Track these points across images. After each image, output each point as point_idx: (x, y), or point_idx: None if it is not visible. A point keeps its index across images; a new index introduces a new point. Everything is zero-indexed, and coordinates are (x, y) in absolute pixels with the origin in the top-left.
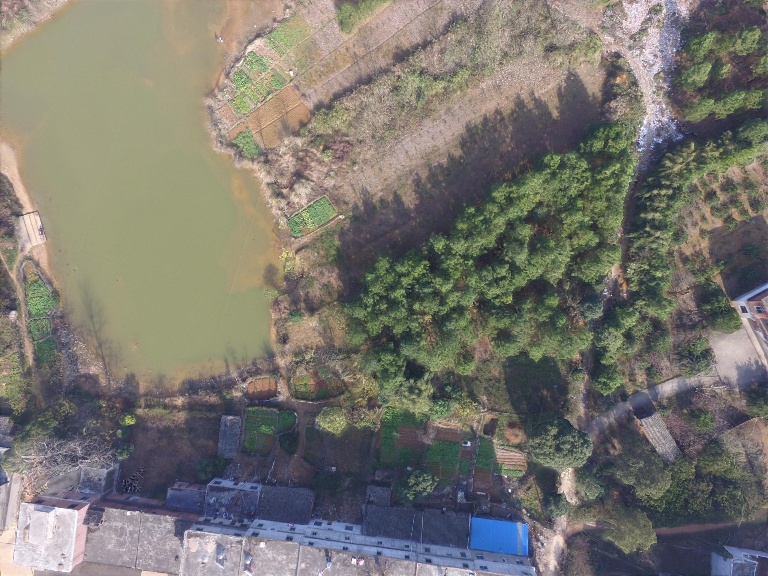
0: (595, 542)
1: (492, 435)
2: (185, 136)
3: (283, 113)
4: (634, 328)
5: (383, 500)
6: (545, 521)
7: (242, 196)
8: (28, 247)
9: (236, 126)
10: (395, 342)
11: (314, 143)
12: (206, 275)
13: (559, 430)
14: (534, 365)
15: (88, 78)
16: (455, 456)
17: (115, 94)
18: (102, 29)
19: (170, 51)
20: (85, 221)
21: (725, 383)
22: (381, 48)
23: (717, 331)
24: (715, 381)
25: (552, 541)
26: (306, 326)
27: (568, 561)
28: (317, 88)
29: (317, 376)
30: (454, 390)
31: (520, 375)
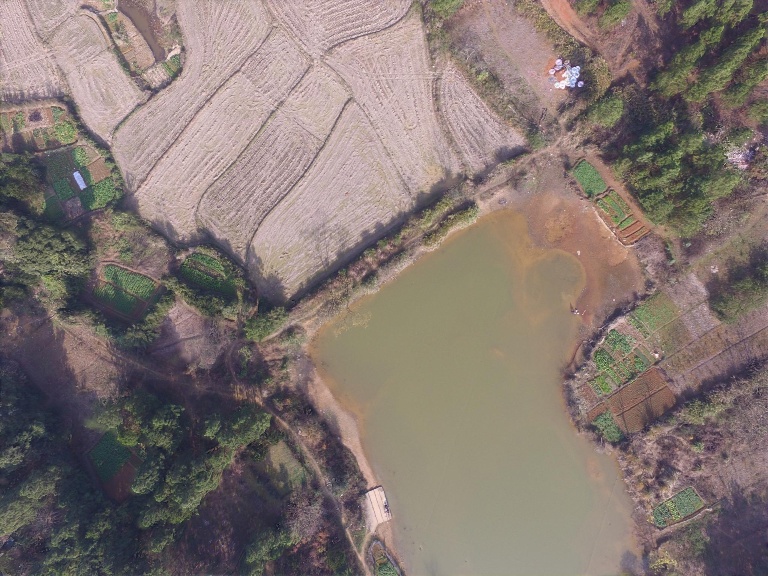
0: None
1: None
2: (538, 412)
3: (646, 396)
4: None
5: None
6: None
7: (599, 479)
8: (374, 526)
9: (596, 407)
10: None
11: (682, 432)
12: (559, 559)
13: None
14: None
15: (434, 345)
16: None
17: (463, 364)
18: (447, 293)
19: (522, 321)
20: (431, 497)
21: None
22: (756, 337)
23: None
24: None
25: None
26: None
27: None
28: (685, 374)
29: None
30: None
31: None
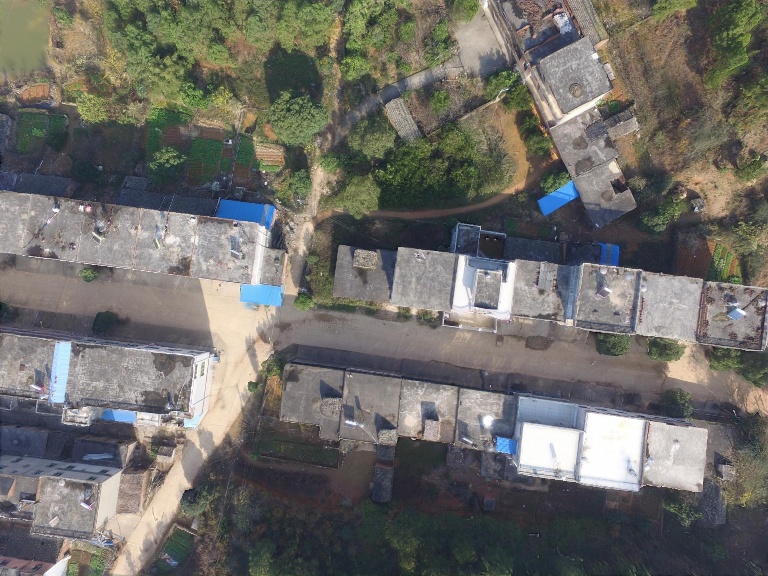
0: None
1: (252, 132)
2: None
3: None
4: (380, 17)
5: (138, 186)
6: (295, 208)
7: None
8: None
9: None
10: (144, 22)
11: None
12: None
13: (292, 96)
14: (293, 65)
15: None
16: (216, 152)
17: None
18: None
19: None
20: None
21: (468, 73)
22: None
23: (459, 20)
24: (459, 72)
25: (302, 227)
26: (80, 35)
27: (315, 244)
28: None
29: (89, 83)
30: (216, 89)
31: (280, 74)
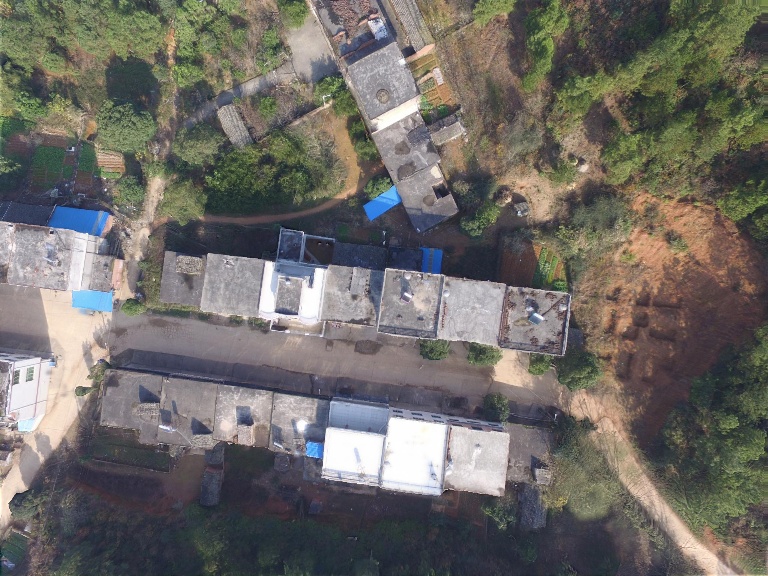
0: (174, 230)
1: (93, 140)
2: None
3: None
4: (212, 24)
5: None
6: (132, 214)
7: None
8: None
9: None
10: None
11: None
12: None
13: (115, 104)
14: (134, 72)
15: None
16: (58, 160)
17: None
18: None
19: None
20: None
21: (300, 79)
22: None
23: (290, 26)
24: (292, 78)
25: (139, 233)
26: None
27: (151, 250)
28: None
29: None
30: None
31: (120, 82)
